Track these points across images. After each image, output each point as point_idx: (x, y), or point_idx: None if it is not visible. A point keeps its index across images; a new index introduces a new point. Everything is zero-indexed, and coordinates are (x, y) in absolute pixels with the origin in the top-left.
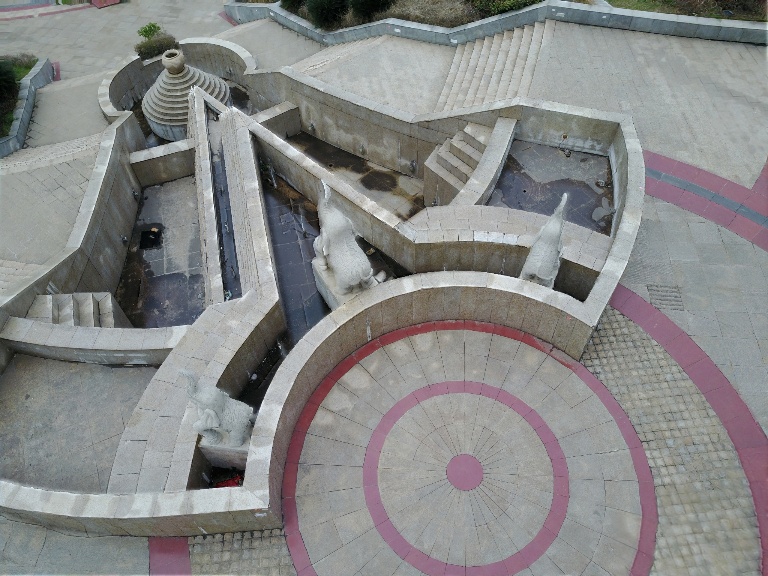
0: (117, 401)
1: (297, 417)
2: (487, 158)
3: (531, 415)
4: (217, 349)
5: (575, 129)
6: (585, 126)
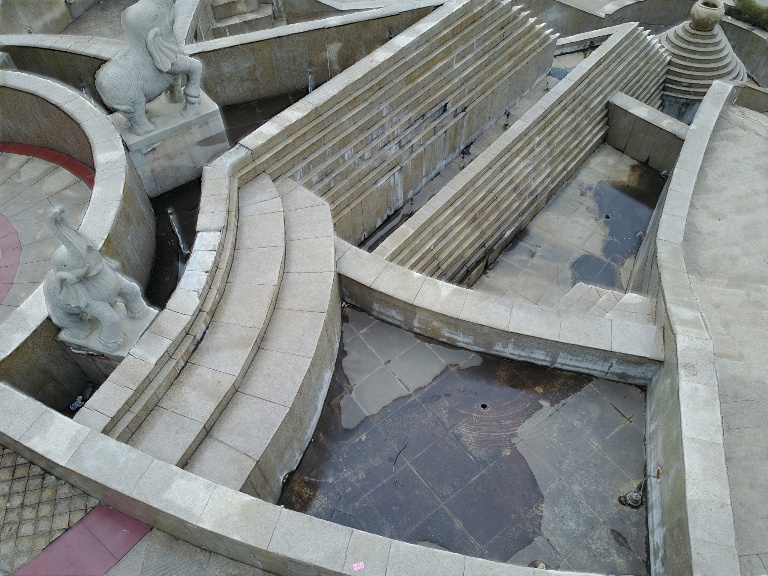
0: None
1: (22, 140)
2: (517, 309)
3: None
4: None
5: (670, 483)
6: (676, 499)
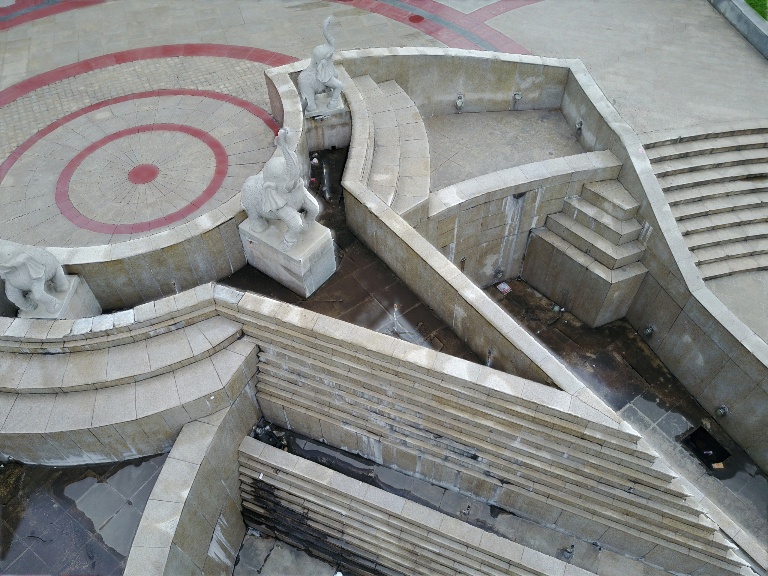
0: (475, 172)
1: None
2: None
3: (84, 223)
4: (382, 156)
5: None
6: None
